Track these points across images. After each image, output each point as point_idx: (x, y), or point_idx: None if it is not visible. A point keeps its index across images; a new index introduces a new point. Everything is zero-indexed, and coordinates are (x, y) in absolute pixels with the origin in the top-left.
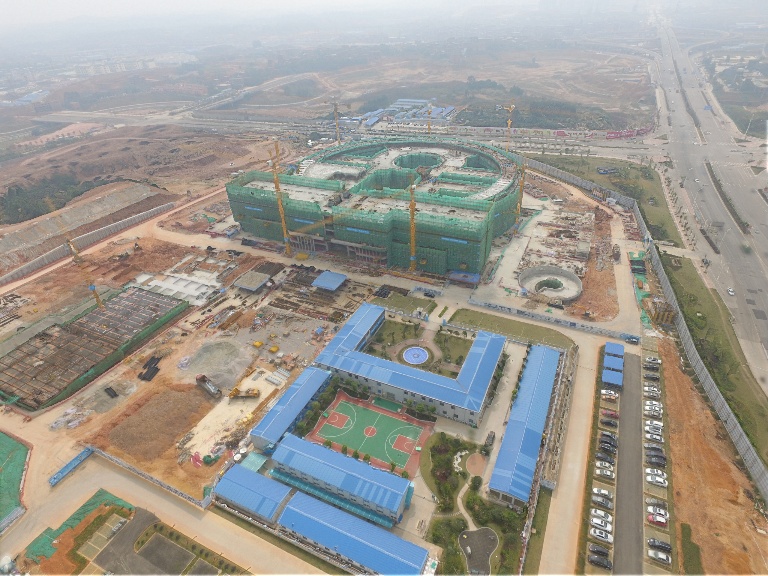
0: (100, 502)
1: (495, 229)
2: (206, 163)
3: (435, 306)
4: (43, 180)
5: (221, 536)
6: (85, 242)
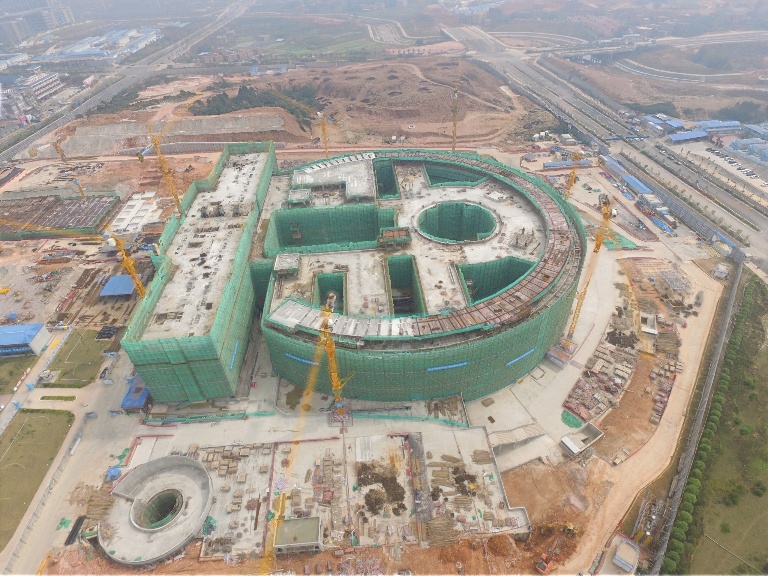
0: None
1: (317, 380)
2: (402, 116)
3: (75, 386)
4: (293, 87)
5: None
6: (190, 148)
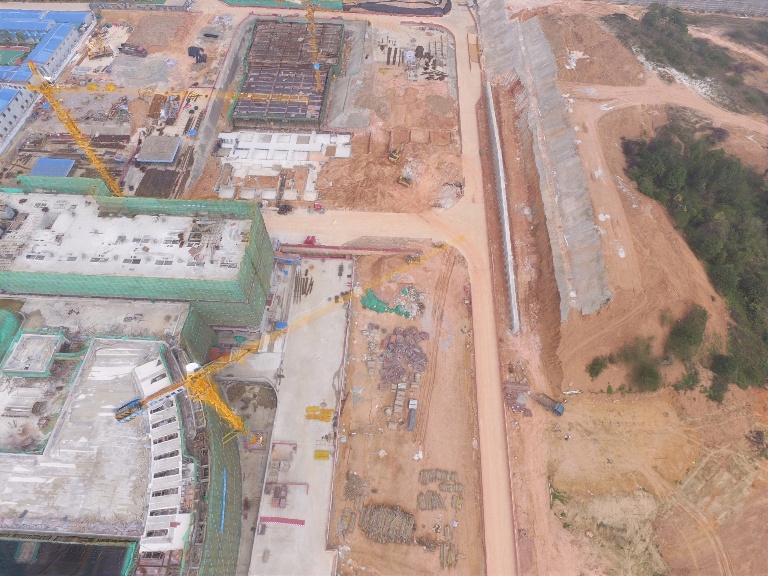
0: (158, 1)
1: None
2: None
3: None
4: None
5: (80, 6)
6: None
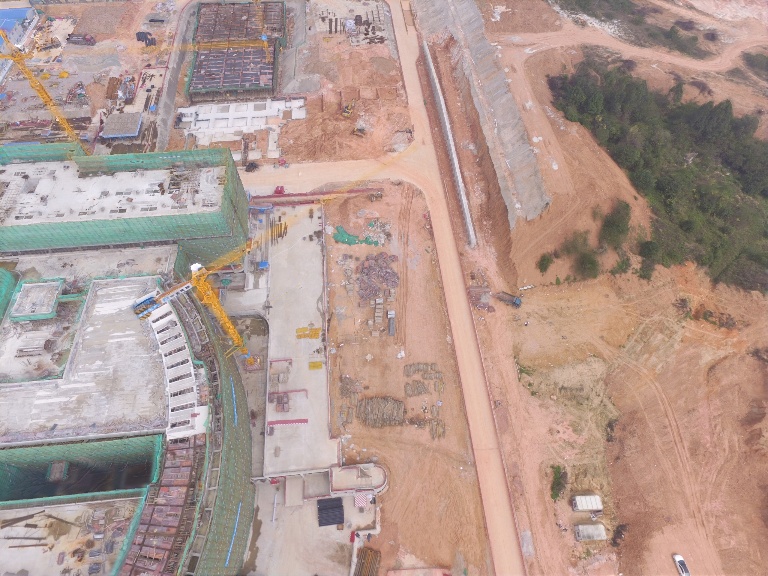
0: None
1: None
2: None
3: None
4: None
5: (19, 4)
6: None
